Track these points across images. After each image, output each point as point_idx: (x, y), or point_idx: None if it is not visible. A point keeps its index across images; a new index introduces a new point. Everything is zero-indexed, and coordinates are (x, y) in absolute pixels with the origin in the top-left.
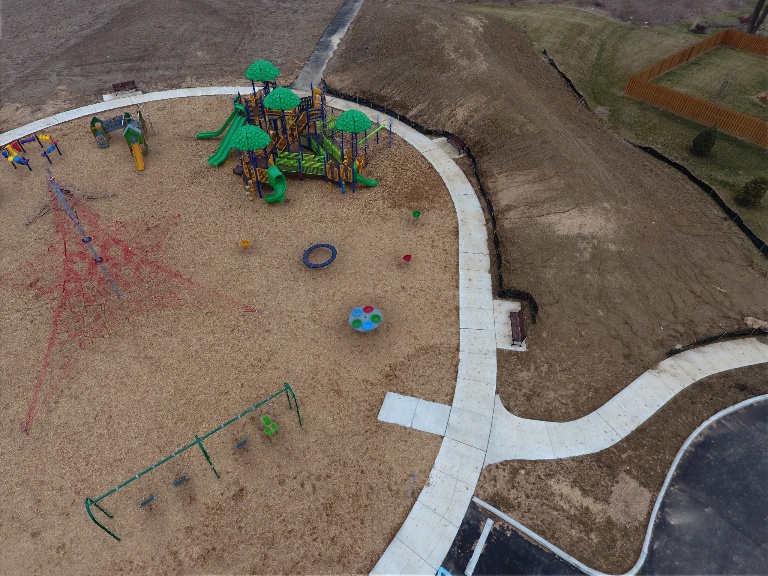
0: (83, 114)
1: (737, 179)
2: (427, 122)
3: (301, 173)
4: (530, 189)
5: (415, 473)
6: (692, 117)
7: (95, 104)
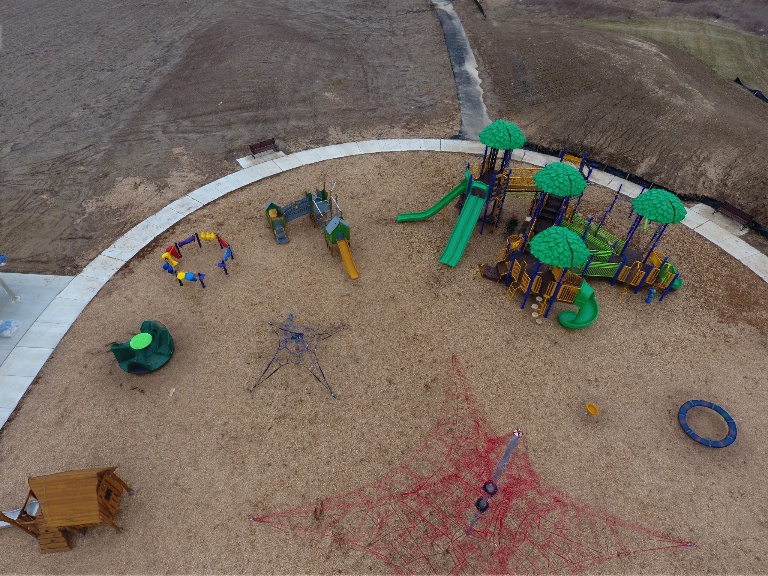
0: (227, 190)
1: None
2: (669, 183)
3: (583, 276)
4: None
5: None
6: None
7: (234, 173)
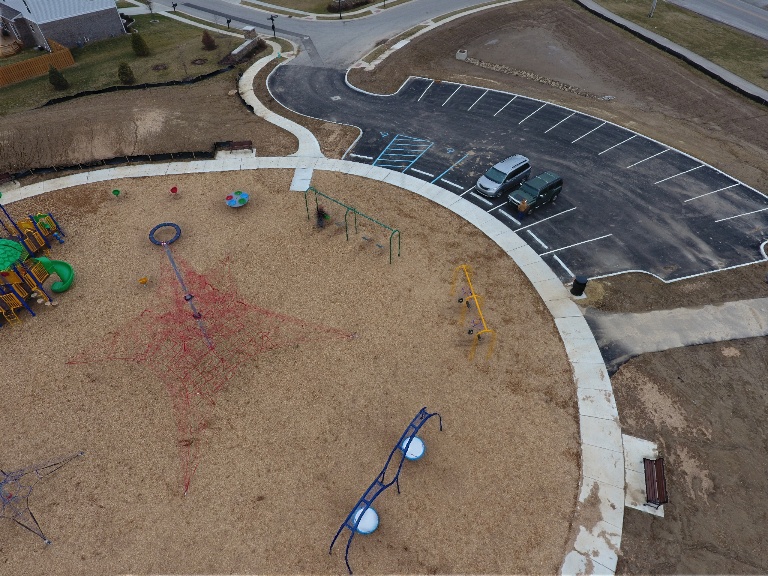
0: None
1: (102, 81)
2: None
3: None
4: (101, 140)
5: (335, 175)
6: (8, 83)
7: None
